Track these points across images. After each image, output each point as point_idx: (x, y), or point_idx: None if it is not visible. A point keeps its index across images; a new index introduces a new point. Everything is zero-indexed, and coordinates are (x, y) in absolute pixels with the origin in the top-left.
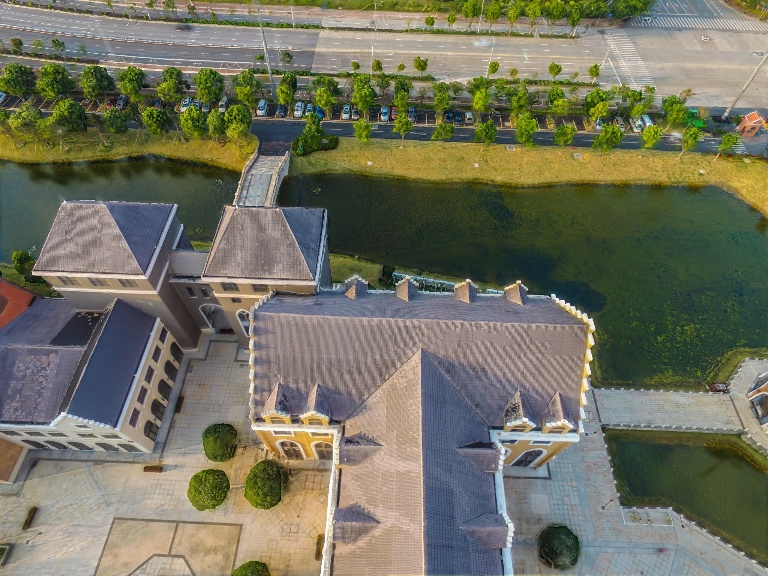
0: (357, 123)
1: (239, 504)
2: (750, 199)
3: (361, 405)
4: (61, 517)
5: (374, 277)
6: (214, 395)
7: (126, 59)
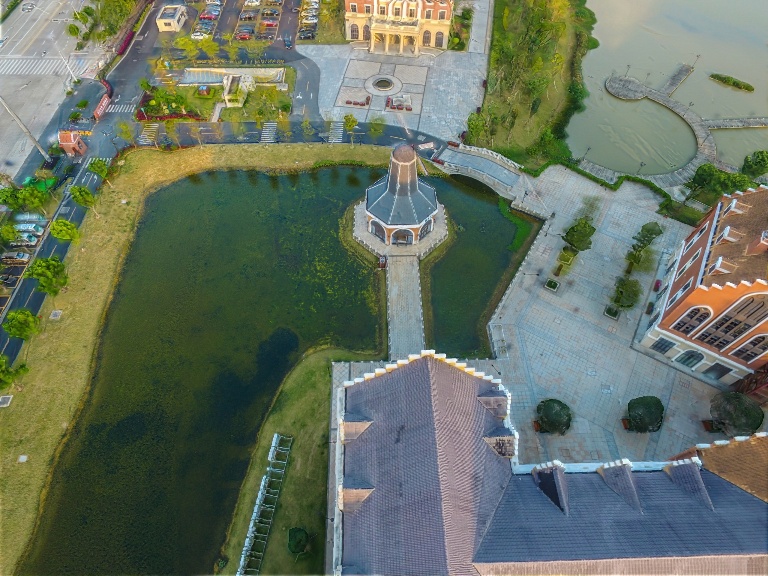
0: None
1: None
2: (173, 177)
3: None
4: None
5: None
6: None
7: None
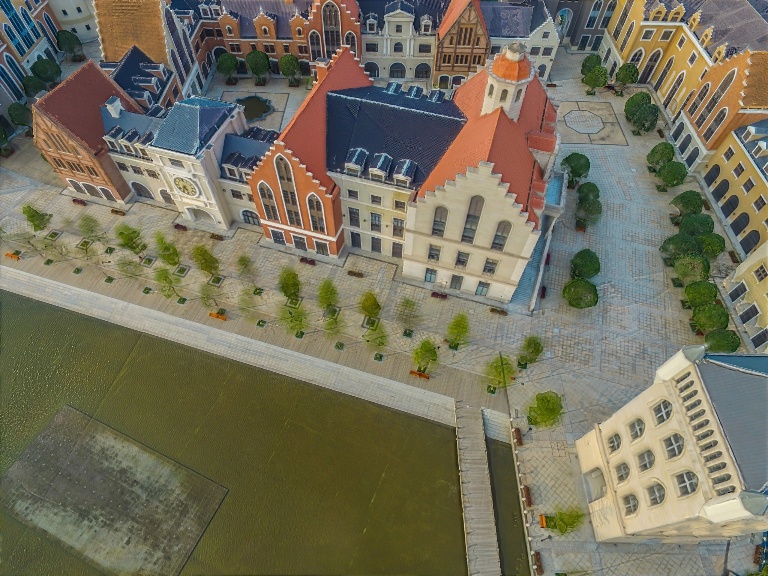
0: None
1: (604, 97)
2: None
3: (696, 10)
4: None
5: None
6: (564, 64)
7: None
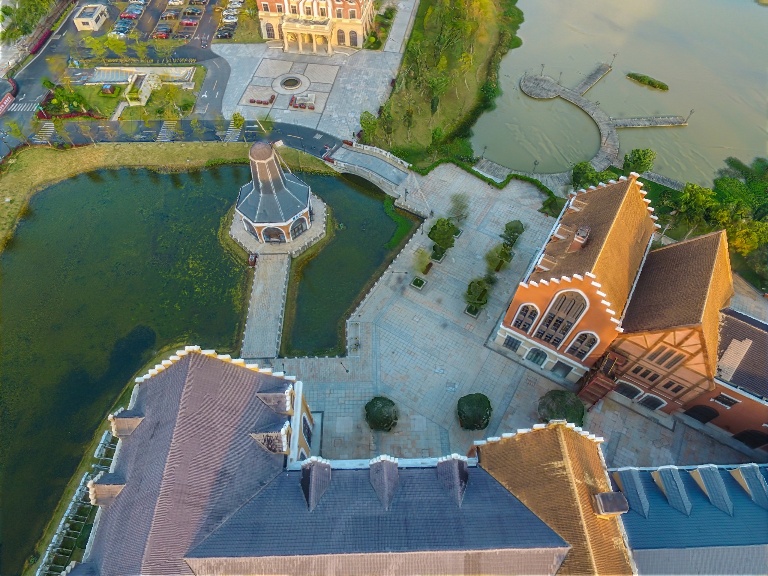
0: None
1: None
2: (63, 175)
3: None
4: None
5: None
6: None
7: None
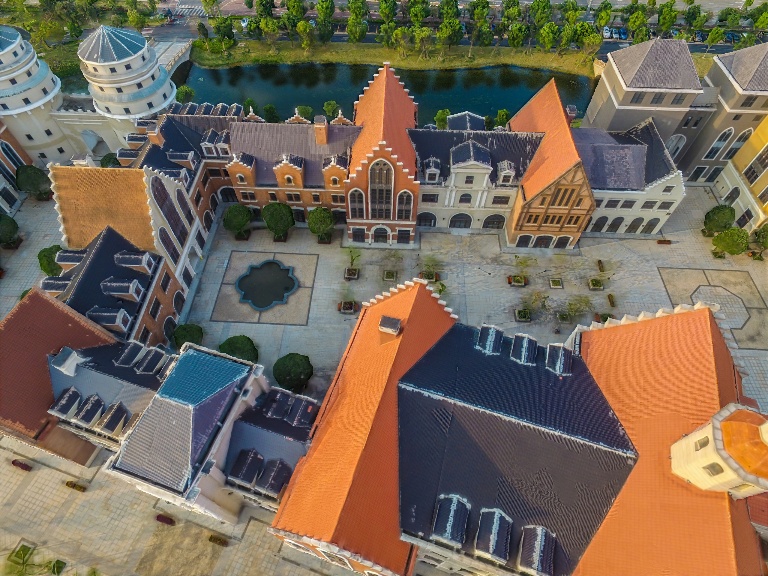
0: None
1: (737, 261)
2: None
3: None
4: (620, 266)
5: None
6: None
7: (437, 0)
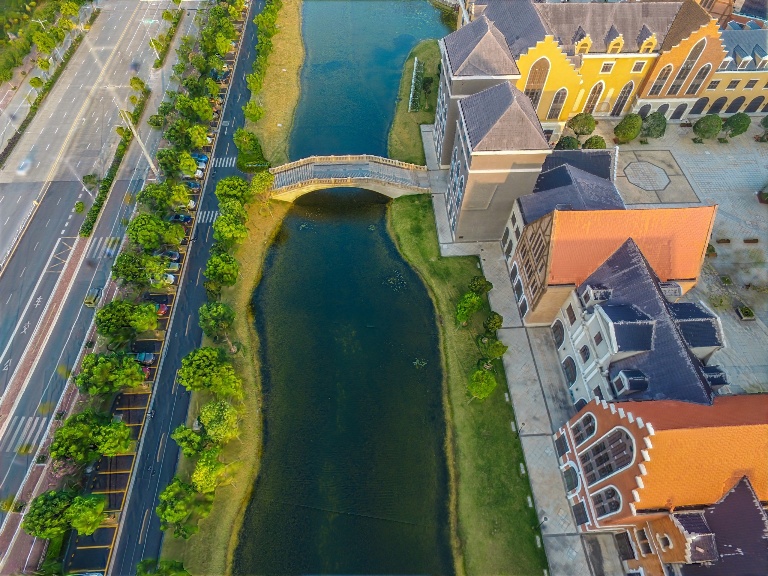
0: (248, 110)
1: None
2: None
3: None
4: None
5: (411, 115)
6: None
7: None
